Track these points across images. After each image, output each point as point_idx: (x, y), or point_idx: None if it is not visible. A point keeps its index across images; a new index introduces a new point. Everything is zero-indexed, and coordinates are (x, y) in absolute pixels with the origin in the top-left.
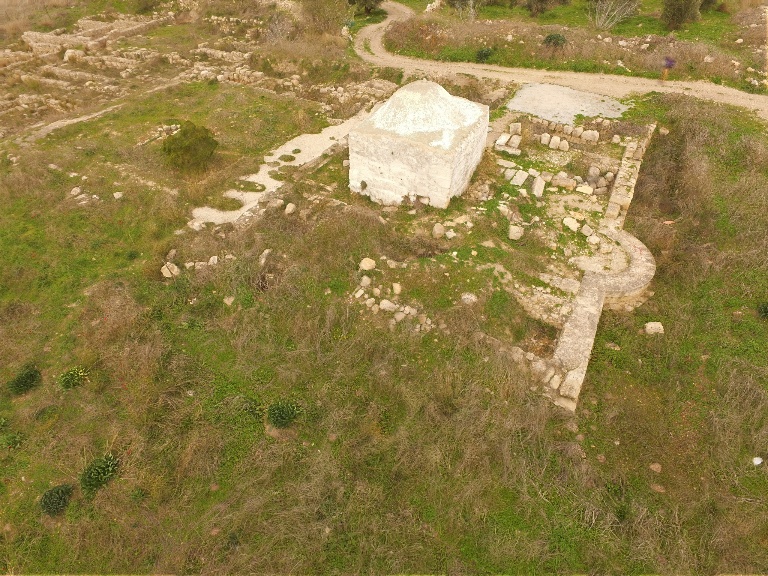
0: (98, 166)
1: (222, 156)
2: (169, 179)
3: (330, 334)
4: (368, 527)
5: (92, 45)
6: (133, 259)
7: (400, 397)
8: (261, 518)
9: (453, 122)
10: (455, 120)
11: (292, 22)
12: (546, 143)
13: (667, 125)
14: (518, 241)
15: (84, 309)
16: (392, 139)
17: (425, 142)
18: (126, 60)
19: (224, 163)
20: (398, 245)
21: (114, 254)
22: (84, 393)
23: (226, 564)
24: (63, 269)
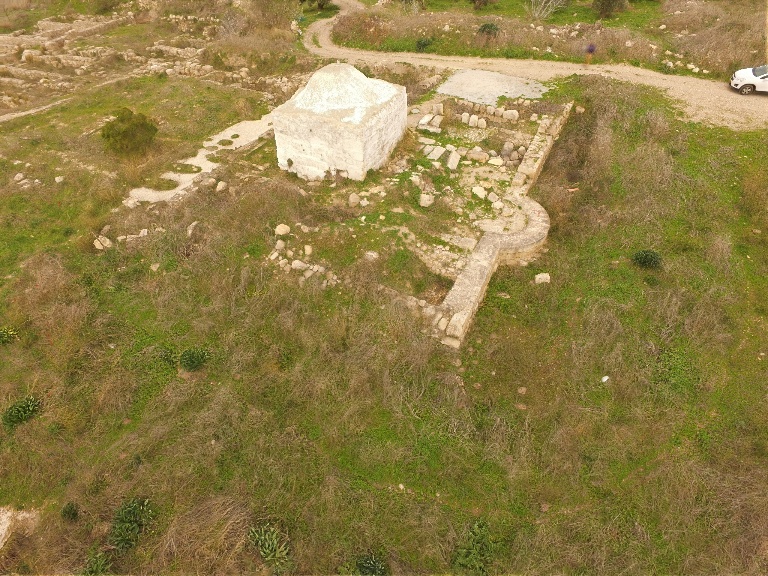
0: (42, 154)
1: (163, 142)
2: (109, 164)
3: (244, 291)
4: (255, 443)
5: (49, 45)
6: (69, 235)
7: (300, 340)
8: (166, 444)
9: (366, 100)
10: (368, 98)
11: (247, 19)
12: (466, 122)
13: (583, 104)
14: (429, 208)
15: (18, 279)
16: (309, 117)
17: (338, 118)
18: (81, 58)
19: (164, 148)
20: (316, 214)
21: (51, 231)
22: (13, 349)
23: (130, 481)
24: (1, 245)
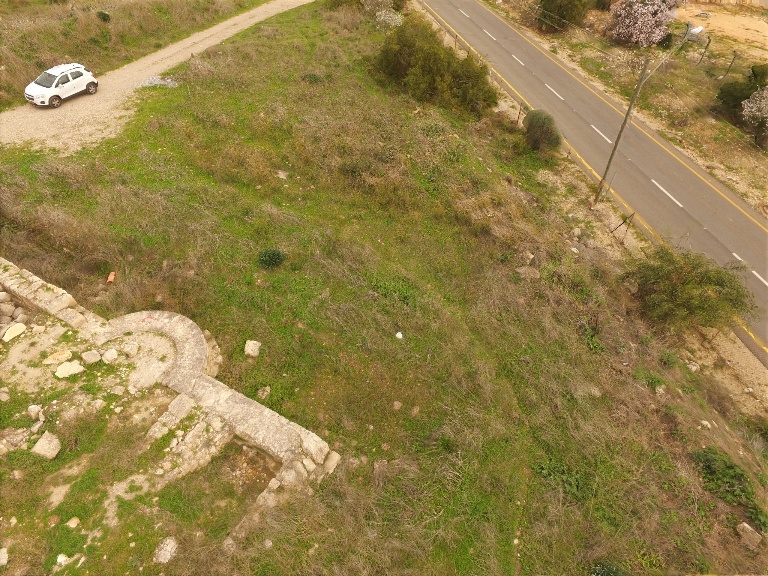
0: None
1: None
2: None
3: None
4: None
5: None
6: None
7: None
8: None
9: None
10: None
11: None
12: None
13: None
14: (64, 447)
15: None
16: None
17: None
18: None
19: None
20: None
21: None
22: None
23: None
24: None
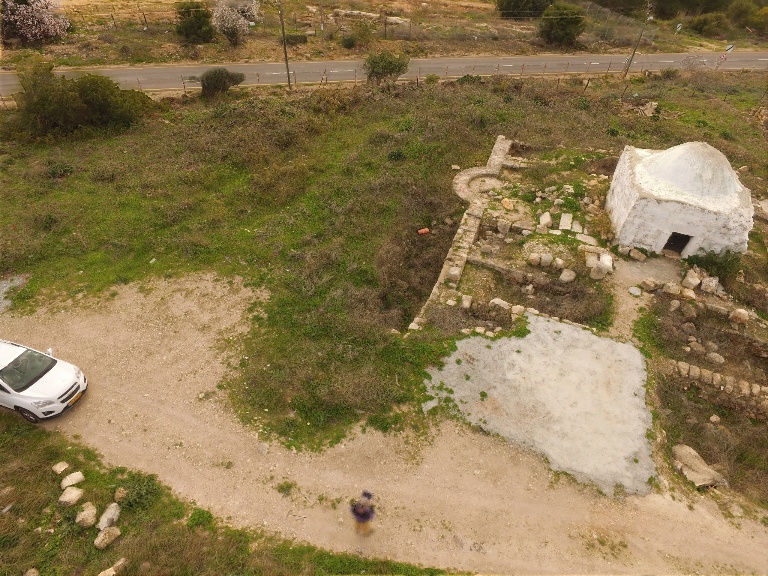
0: None
1: None
2: None
3: None
4: None
5: None
6: None
7: None
8: None
9: None
10: None
11: None
12: None
13: None
14: None
15: (751, 153)
16: None
17: None
18: None
19: None
20: None
21: None
22: None
23: None
24: None
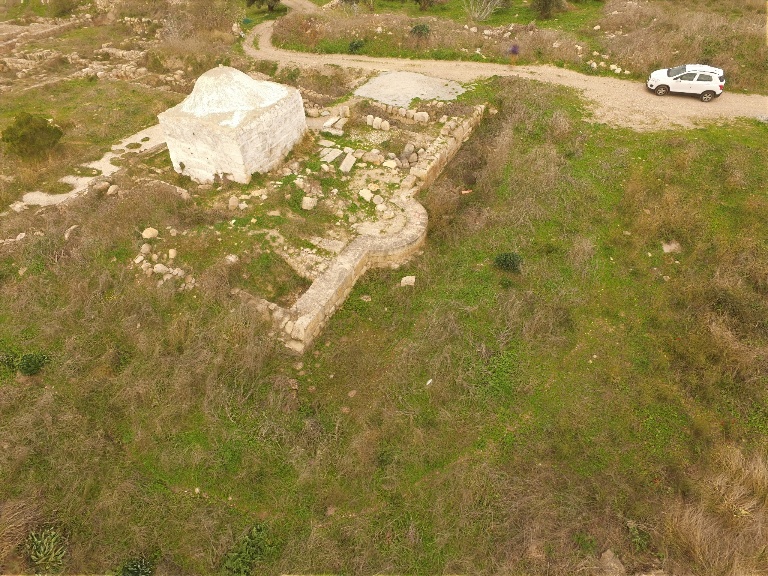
0: None
1: (70, 145)
2: (10, 167)
3: (101, 295)
4: (60, 447)
5: None
6: None
7: None
8: None
9: (248, 104)
10: (250, 102)
11: None
12: (370, 124)
13: (496, 105)
14: (311, 211)
15: None
16: (189, 121)
17: (215, 122)
18: (25, 61)
19: (71, 152)
20: (195, 217)
21: None
22: None
23: None
24: None
